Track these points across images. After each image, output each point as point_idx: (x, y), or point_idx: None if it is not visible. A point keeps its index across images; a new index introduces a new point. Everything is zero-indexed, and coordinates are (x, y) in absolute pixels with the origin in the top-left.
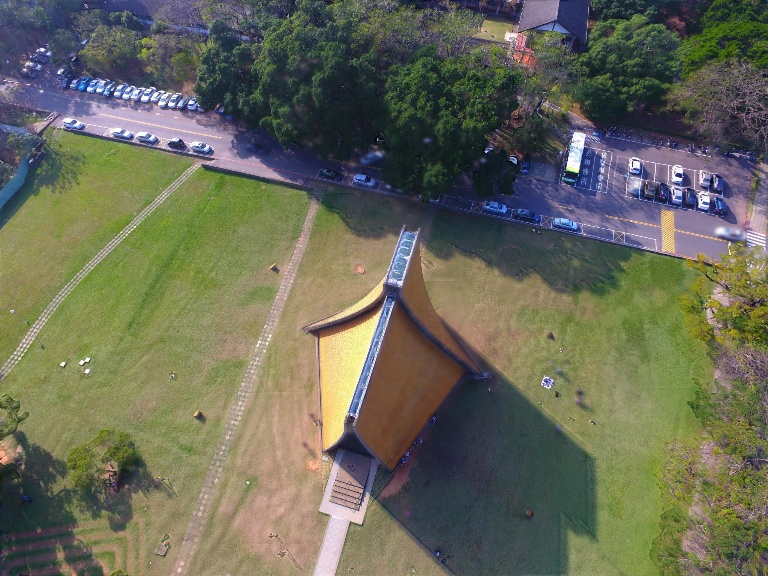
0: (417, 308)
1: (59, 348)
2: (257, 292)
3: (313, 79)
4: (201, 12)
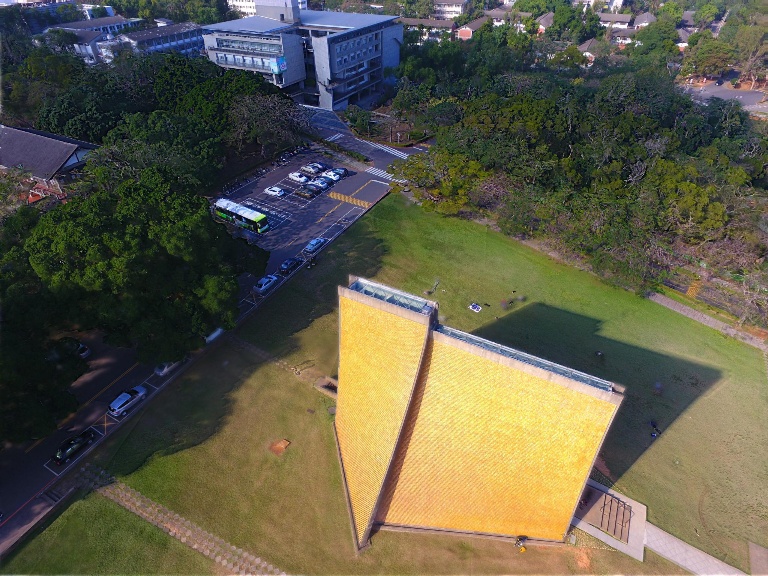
0: None
1: None
2: None
3: None
4: None
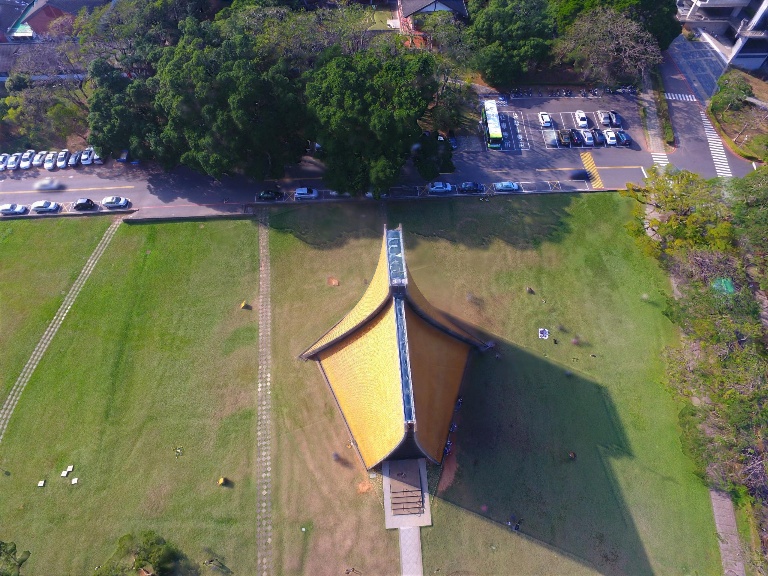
0: (419, 301)
1: (29, 467)
2: (237, 336)
3: (230, 102)
4: (67, 56)
